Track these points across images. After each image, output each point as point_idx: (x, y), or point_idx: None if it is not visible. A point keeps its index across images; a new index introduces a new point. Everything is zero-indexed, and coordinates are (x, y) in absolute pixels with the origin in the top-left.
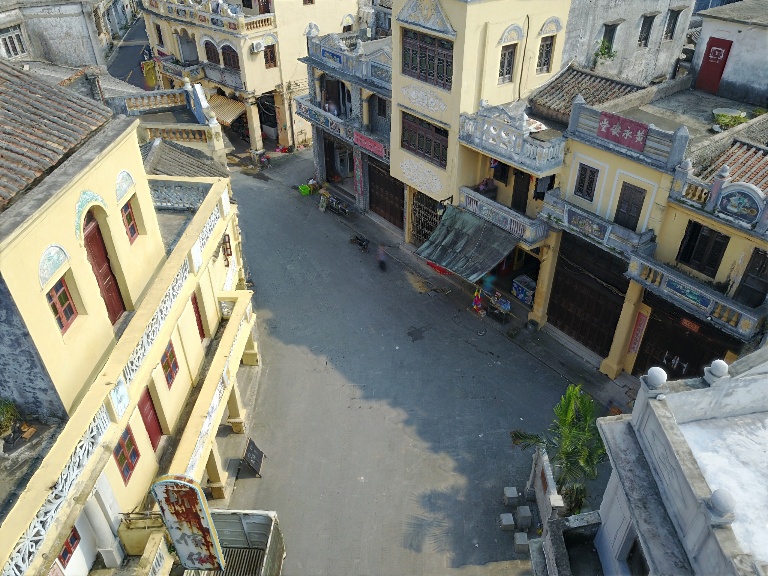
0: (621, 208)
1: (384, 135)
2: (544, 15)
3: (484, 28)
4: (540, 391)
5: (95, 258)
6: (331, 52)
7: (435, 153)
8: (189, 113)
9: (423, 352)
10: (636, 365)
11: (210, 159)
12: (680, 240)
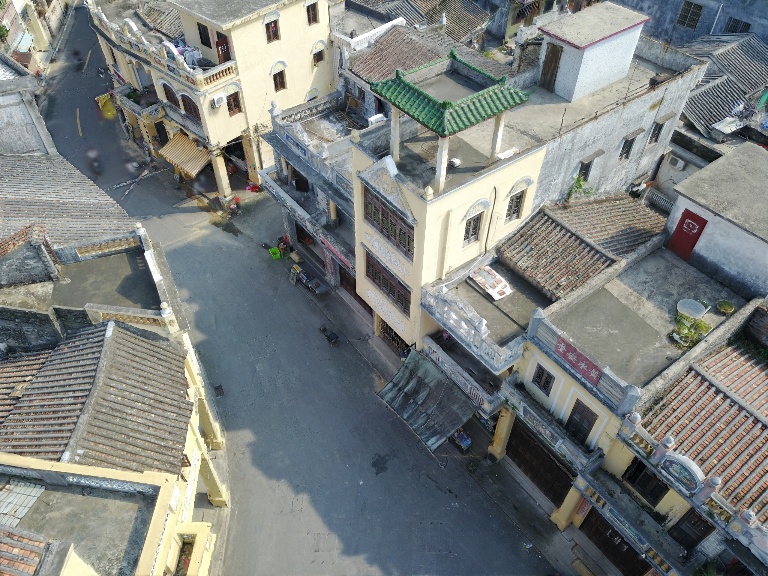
0: (574, 416)
1: (352, 229)
2: (513, 179)
3: (446, 216)
4: (492, 543)
5: None
6: (295, 141)
7: (399, 299)
8: (144, 257)
9: (385, 489)
10: (583, 525)
11: (166, 340)
12: (626, 465)
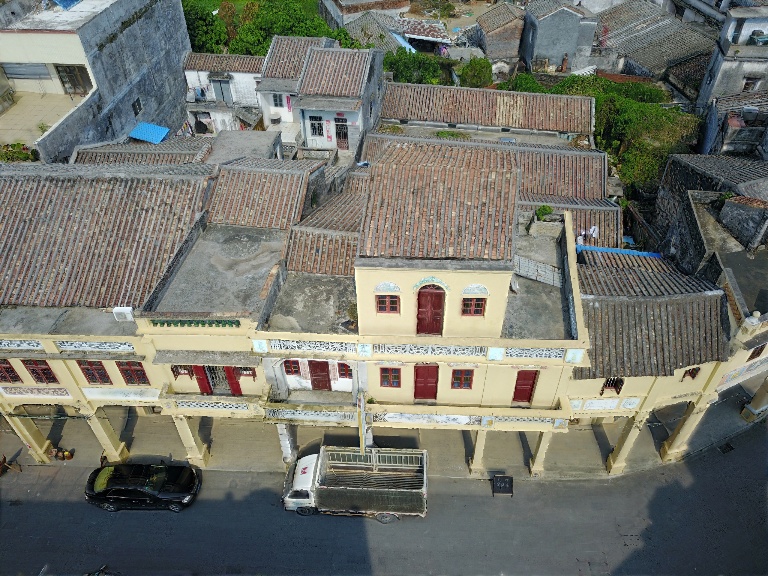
0: None
1: None
2: None
3: None
4: None
5: (434, 303)
6: None
7: None
8: None
9: None
10: None
11: (728, 338)
12: None
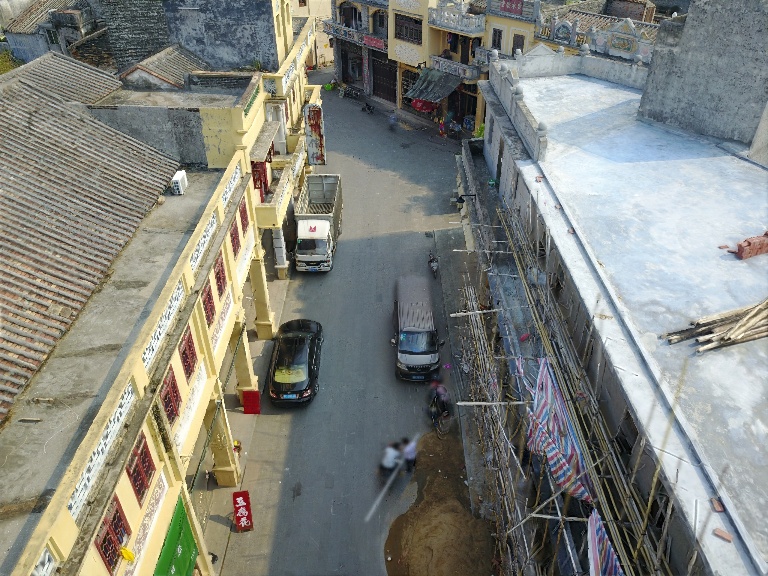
0: (514, 50)
1: None
2: None
3: None
4: None
5: None
6: None
7: (415, 37)
8: None
9: (410, 152)
10: None
11: None
12: None
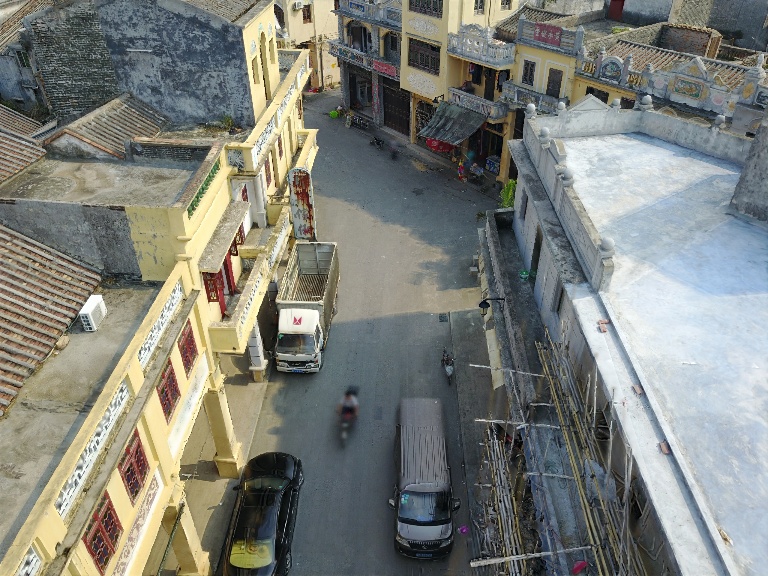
0: (549, 86)
1: None
2: None
3: None
4: None
5: None
6: (357, 4)
7: (432, 65)
8: None
9: (423, 200)
10: None
11: None
12: None
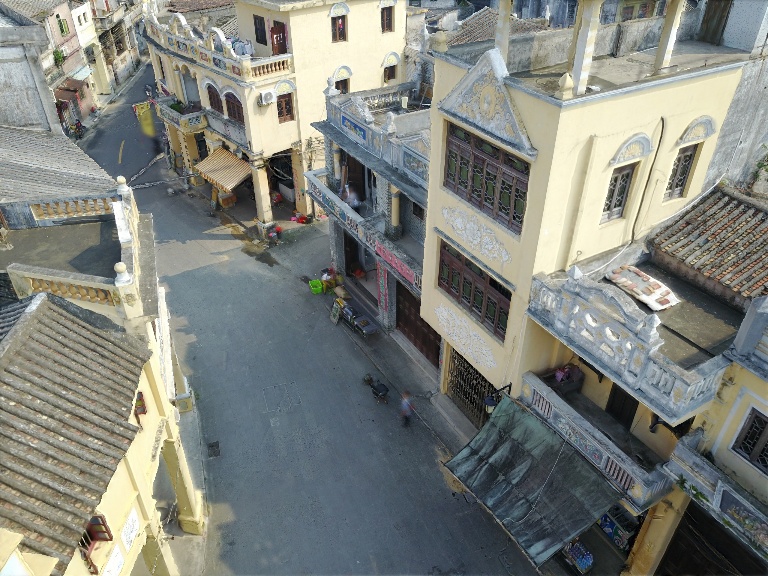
0: None
1: (419, 241)
2: (689, 115)
3: (587, 145)
4: None
5: None
6: (353, 122)
7: (488, 313)
8: None
9: None
10: None
11: (121, 330)
12: None
